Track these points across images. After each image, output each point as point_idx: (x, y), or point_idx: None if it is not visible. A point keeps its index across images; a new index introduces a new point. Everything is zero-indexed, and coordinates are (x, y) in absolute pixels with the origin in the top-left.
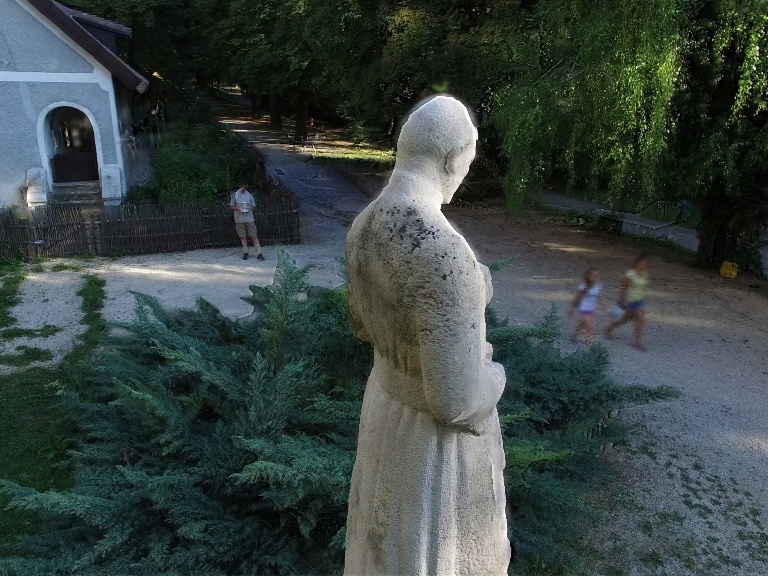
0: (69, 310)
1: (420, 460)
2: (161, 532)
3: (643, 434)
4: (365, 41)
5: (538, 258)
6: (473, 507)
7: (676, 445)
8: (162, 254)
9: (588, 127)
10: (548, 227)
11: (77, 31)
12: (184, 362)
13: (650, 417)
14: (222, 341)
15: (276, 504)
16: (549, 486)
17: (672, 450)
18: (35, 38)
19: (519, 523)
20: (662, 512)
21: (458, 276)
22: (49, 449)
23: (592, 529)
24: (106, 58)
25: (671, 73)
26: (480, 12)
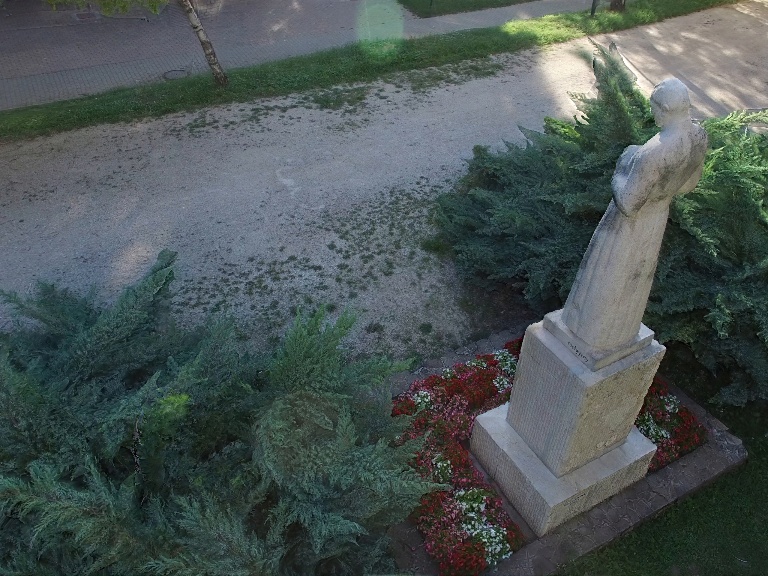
0: None
1: None
2: None
3: None
4: None
5: None
6: None
7: None
8: None
9: None
10: None
11: None
12: None
13: (86, 306)
14: None
15: None
16: None
17: None
18: None
19: None
20: None
21: None
22: None
23: None
24: None
25: None
26: None
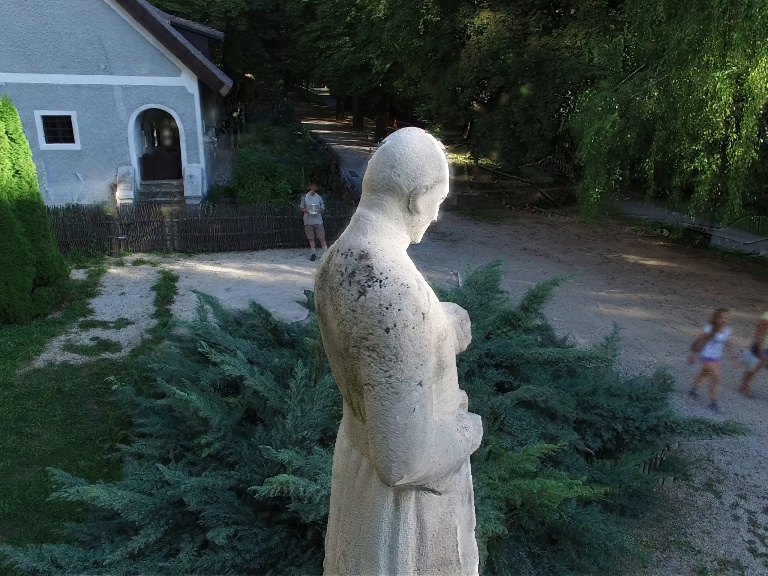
0: (142, 304)
1: (376, 515)
2: (194, 532)
3: (709, 469)
4: (443, 44)
5: (613, 270)
6: (434, 569)
7: (746, 484)
8: (234, 252)
9: (671, 135)
10: (628, 238)
11: (167, 37)
12: (229, 366)
13: (719, 451)
14: (275, 344)
15: (302, 517)
16: (590, 522)
17: (740, 490)
18: (129, 44)
19: (557, 557)
20: (721, 558)
21: (402, 330)
22: (107, 439)
23: (640, 569)
24: (193, 62)
25: (764, 79)
26: (564, 13)
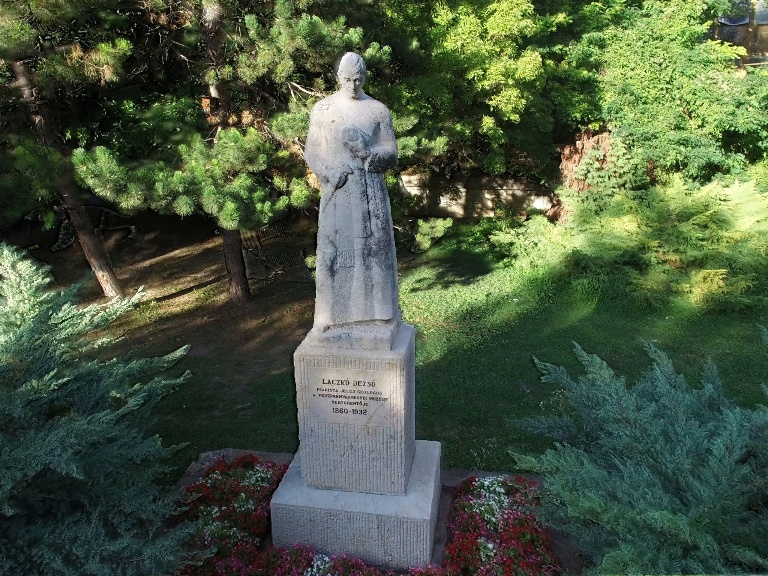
0: None
1: None
2: None
3: None
4: None
5: None
6: None
7: None
8: None
9: None
10: None
11: None
12: None
13: None
14: None
15: None
16: None
17: None
18: None
19: None
20: None
21: None
22: None
23: None
24: None
25: None
26: None
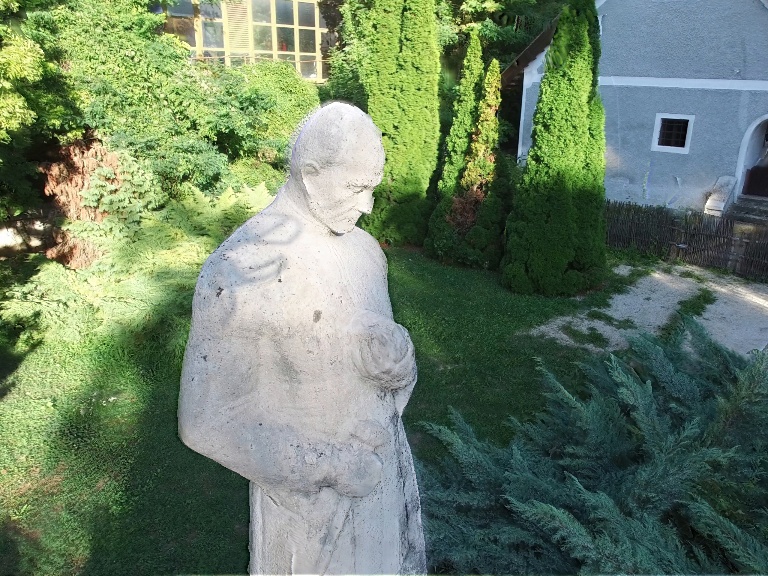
0: (658, 314)
1: None
2: (513, 523)
3: None
4: None
5: None
6: None
7: None
8: None
9: None
10: None
11: None
12: (627, 390)
13: None
14: None
15: None
16: None
17: None
18: None
19: None
20: None
21: (197, 295)
22: None
23: None
24: None
25: None
26: None
